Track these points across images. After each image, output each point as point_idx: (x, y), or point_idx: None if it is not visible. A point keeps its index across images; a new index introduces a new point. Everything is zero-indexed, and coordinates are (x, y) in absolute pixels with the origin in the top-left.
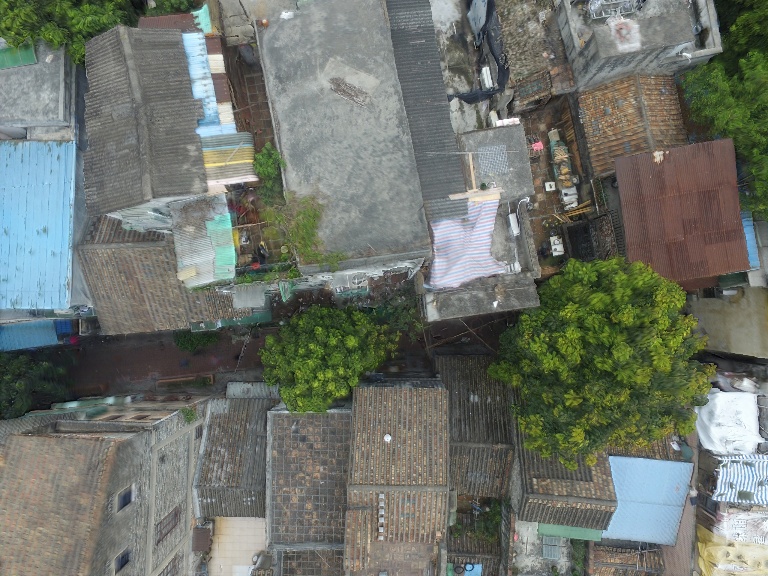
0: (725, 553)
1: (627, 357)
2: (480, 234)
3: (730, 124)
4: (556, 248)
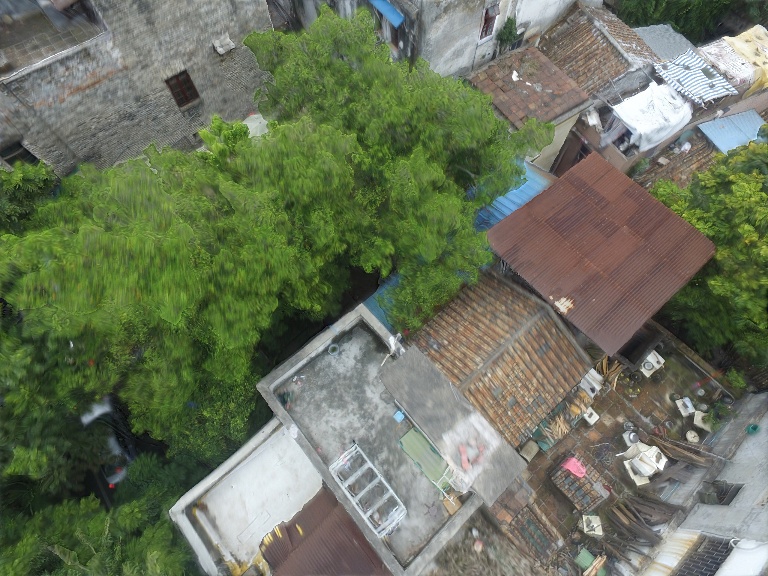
0: (767, 66)
1: None
2: None
3: (488, 246)
4: (657, 363)
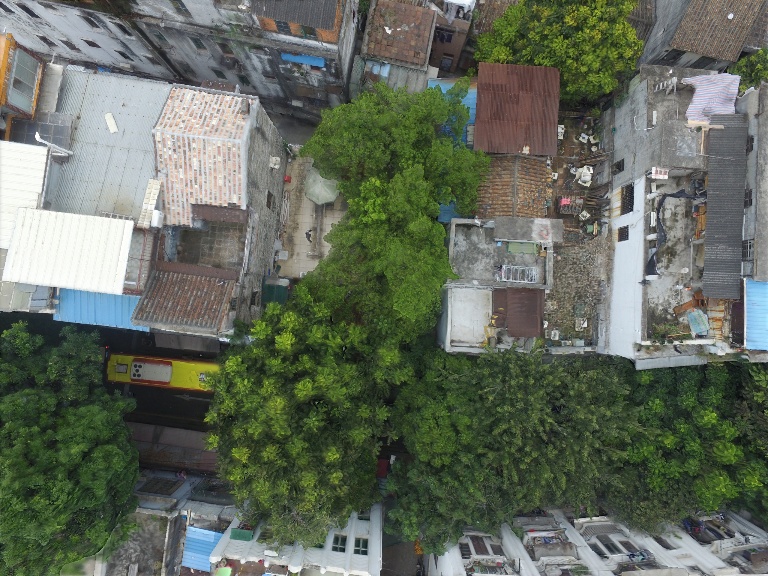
0: None
1: (627, 2)
2: (700, 104)
3: None
4: (562, 130)
